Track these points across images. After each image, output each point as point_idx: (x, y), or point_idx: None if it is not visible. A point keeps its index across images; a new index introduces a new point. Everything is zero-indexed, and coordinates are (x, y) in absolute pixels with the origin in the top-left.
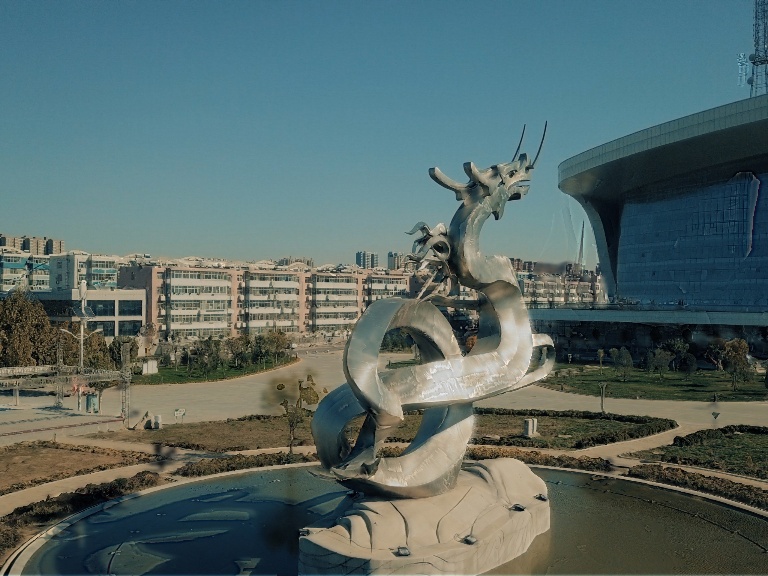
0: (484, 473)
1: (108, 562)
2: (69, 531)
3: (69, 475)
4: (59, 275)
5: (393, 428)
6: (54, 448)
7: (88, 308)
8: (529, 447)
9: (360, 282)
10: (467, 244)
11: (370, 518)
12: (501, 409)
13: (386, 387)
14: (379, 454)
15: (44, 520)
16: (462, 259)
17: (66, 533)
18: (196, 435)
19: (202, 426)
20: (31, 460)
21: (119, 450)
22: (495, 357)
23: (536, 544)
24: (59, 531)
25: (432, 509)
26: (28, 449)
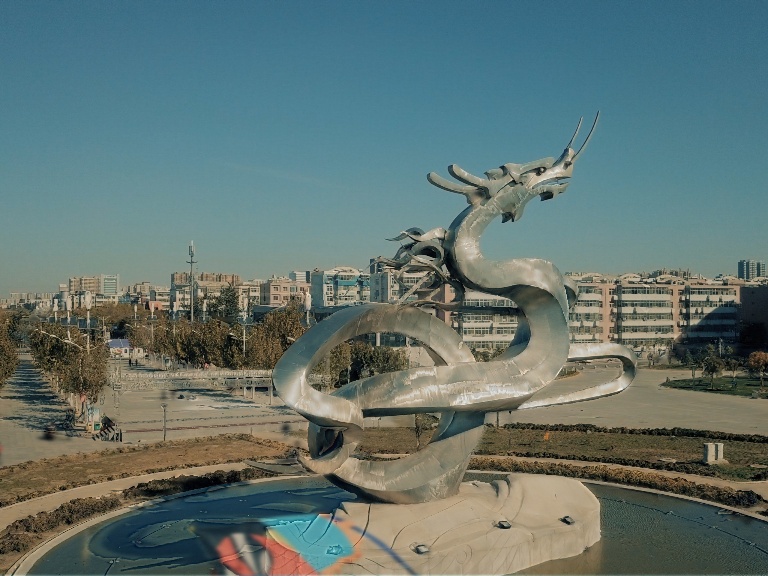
0: (502, 487)
1: (151, 532)
2: (159, 505)
3: (220, 462)
4: (377, 291)
5: (360, 431)
6: (246, 440)
7: (313, 319)
8: (691, 474)
9: (676, 293)
10: (461, 248)
11: (335, 517)
12: (717, 432)
13: (363, 391)
14: (507, 467)
15: (152, 495)
16: (457, 264)
17: (155, 507)
18: (375, 438)
19: (393, 431)
20: (215, 449)
21: (289, 446)
22: (507, 366)
23: (549, 569)
24: (150, 504)
25: (405, 515)
26: (225, 440)
